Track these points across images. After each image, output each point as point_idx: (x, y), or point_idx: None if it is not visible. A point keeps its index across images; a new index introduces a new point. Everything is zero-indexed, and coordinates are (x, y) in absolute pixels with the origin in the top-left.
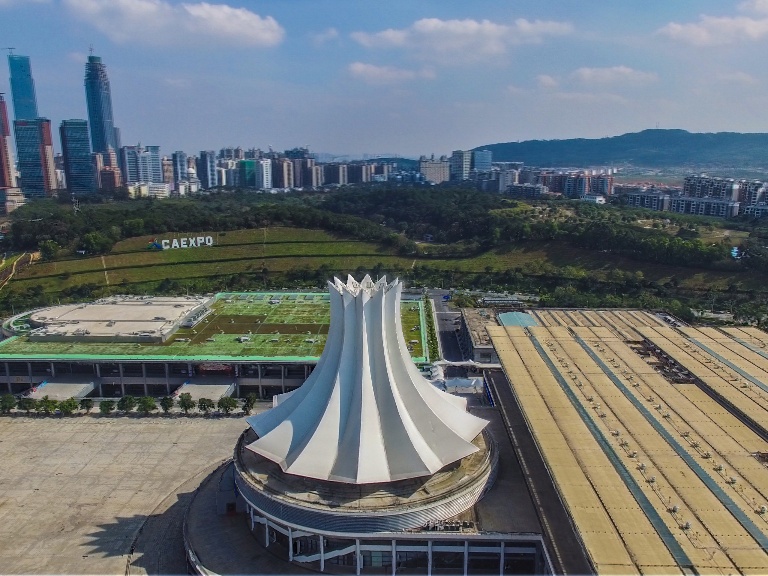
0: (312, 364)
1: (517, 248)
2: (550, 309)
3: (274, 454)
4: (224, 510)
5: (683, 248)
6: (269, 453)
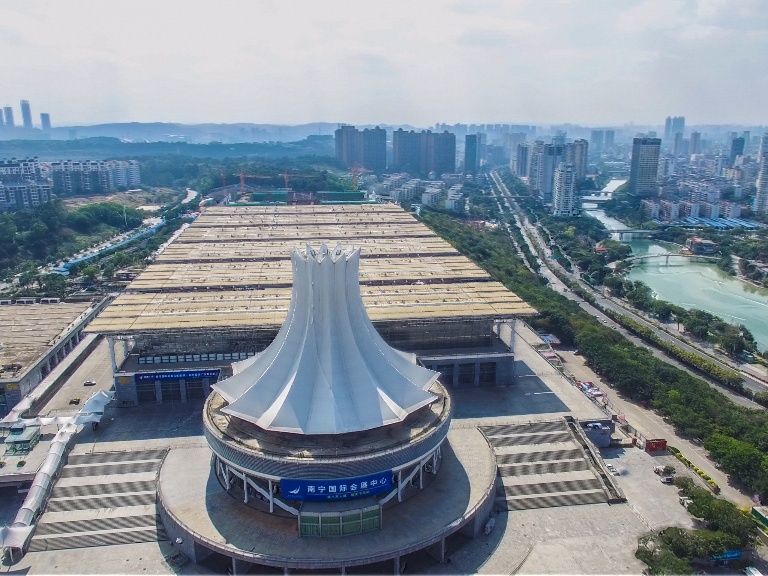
0: None
1: None
2: None
3: None
4: None
5: None
6: (402, 414)
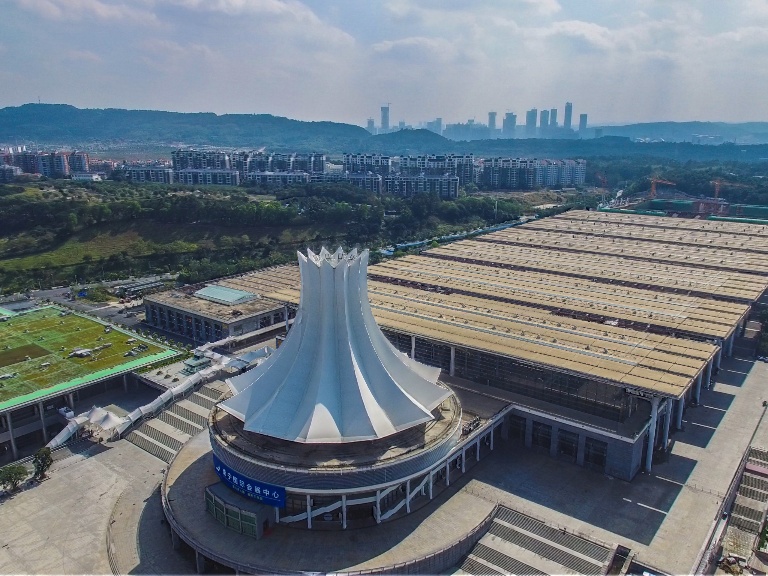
0: (56, 396)
1: (101, 232)
2: (222, 279)
3: (331, 437)
4: (261, 532)
5: (269, 210)
6: (327, 439)
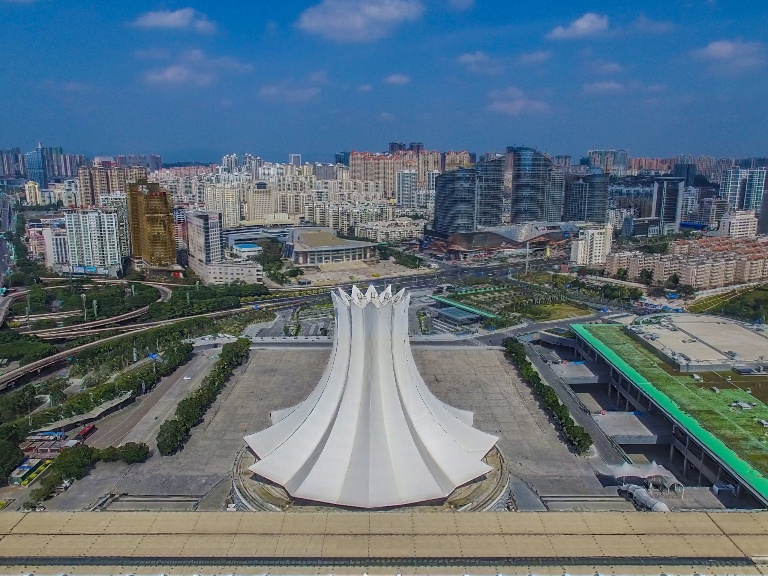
0: (712, 458)
1: None
2: None
3: None
4: None
5: None
6: None
